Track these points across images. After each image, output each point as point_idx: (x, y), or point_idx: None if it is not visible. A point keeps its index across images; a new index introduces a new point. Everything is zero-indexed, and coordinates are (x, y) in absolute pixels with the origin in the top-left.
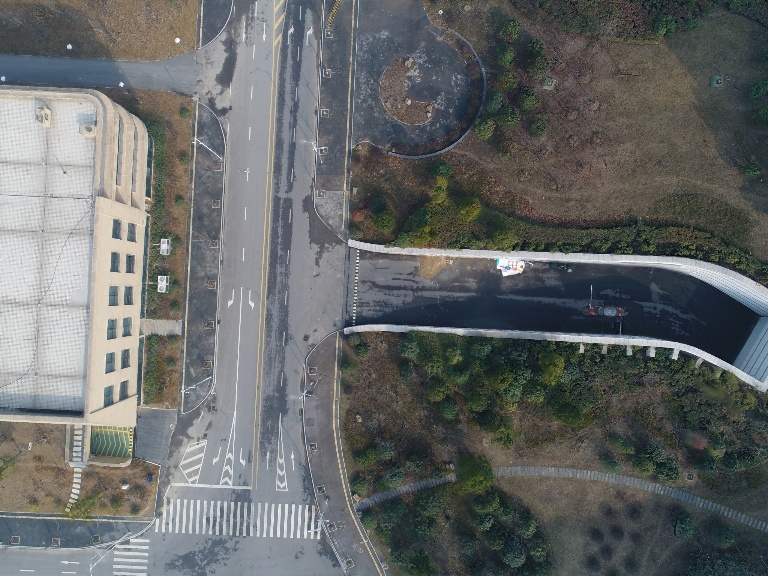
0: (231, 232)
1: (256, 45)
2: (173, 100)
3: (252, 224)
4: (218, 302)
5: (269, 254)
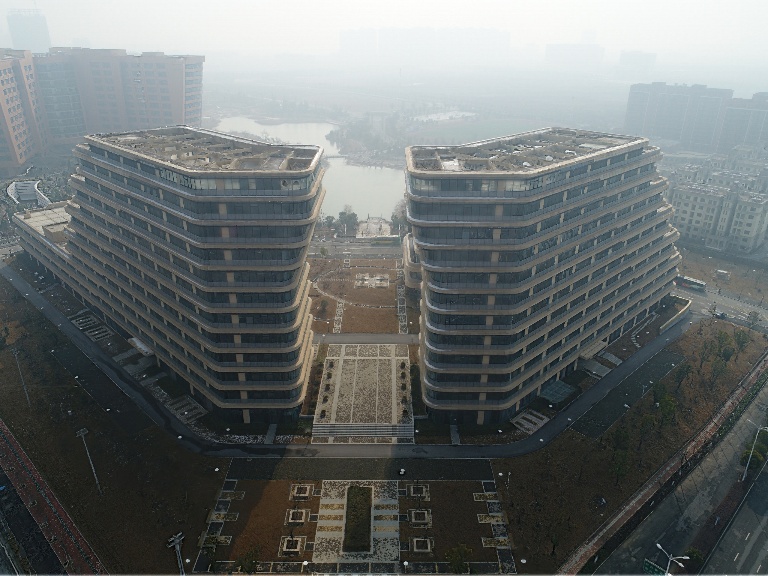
0: None
1: None
2: (7, 259)
3: None
4: None
5: None
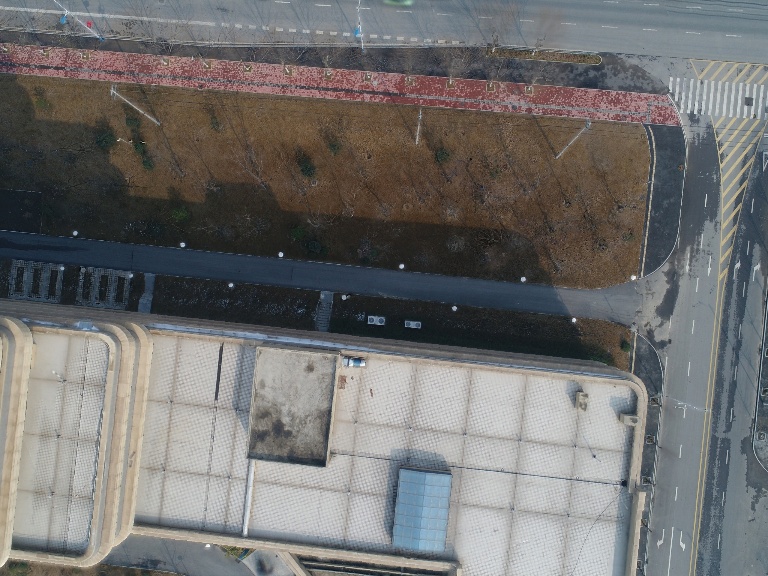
0: (664, 469)
1: (700, 278)
2: (613, 331)
3: (687, 463)
4: (647, 541)
5: (703, 495)
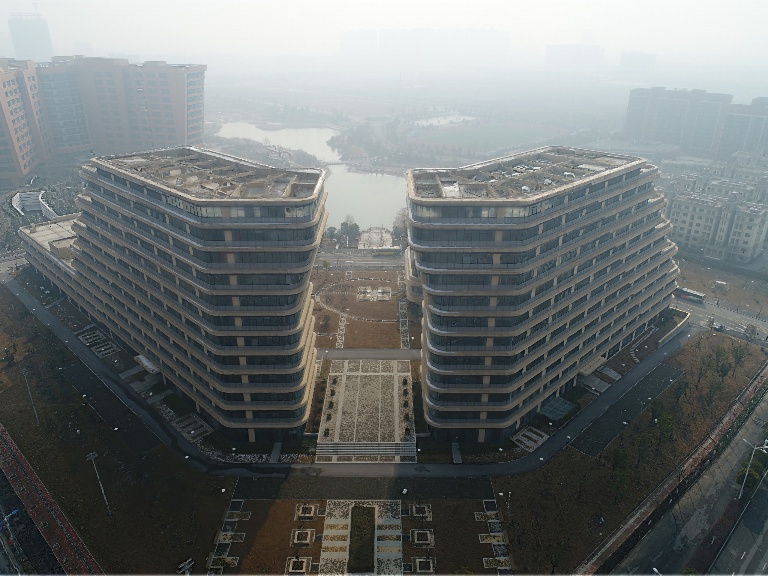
0: None
1: None
2: None
3: None
4: None
5: None
